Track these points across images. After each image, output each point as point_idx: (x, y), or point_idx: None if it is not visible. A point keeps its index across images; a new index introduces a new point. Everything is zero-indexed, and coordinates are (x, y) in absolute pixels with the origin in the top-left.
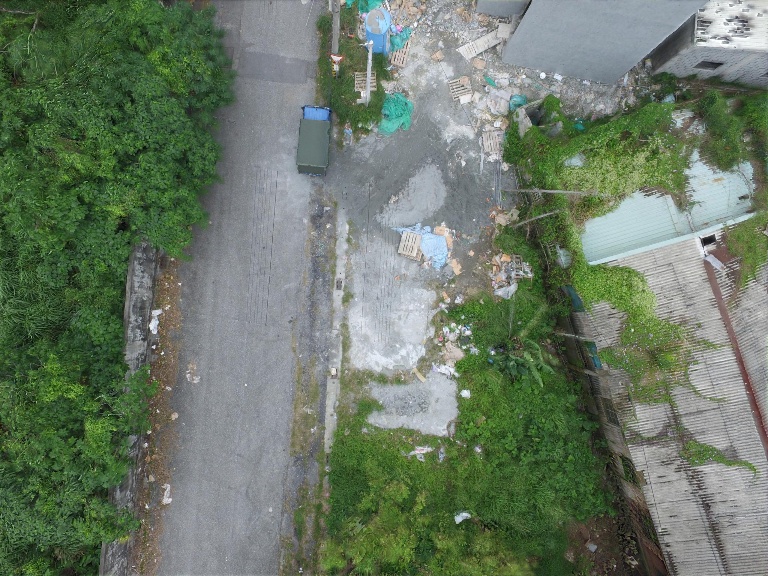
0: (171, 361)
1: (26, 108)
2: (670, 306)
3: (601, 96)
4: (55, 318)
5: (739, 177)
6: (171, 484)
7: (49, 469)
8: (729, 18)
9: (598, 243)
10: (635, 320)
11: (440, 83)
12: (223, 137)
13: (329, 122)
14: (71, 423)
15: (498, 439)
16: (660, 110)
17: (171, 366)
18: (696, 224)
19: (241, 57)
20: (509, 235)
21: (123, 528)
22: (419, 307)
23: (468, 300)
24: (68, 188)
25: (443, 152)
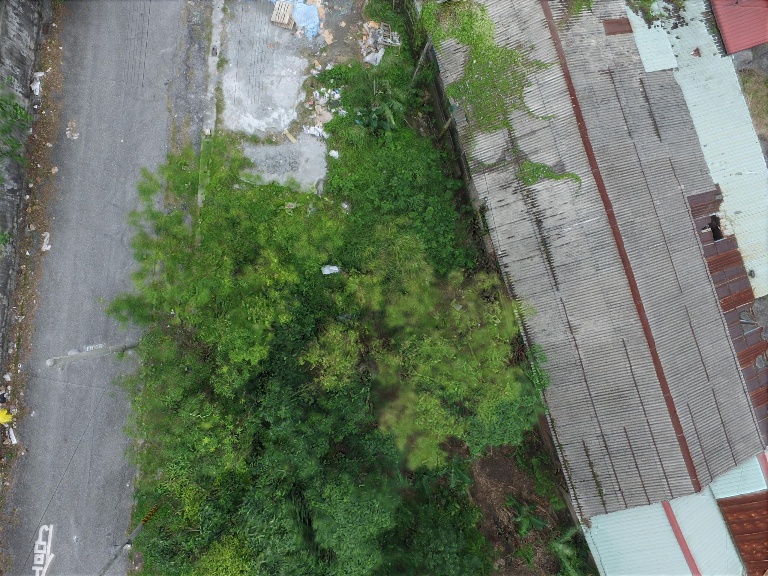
0: (52, 119)
1: None
2: (507, 33)
3: None
4: None
5: None
6: (50, 232)
7: None
8: None
9: None
10: (476, 51)
11: None
12: None
13: None
14: None
15: (361, 191)
16: None
17: (52, 124)
18: None
19: None
20: (377, 3)
21: None
22: (291, 73)
23: (337, 65)
24: None
25: None
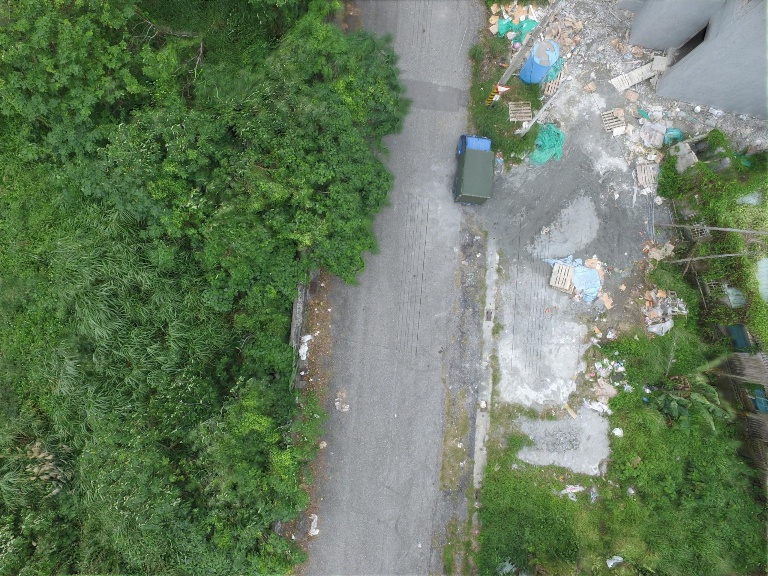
0: (319, 388)
1: (213, 134)
2: None
3: (757, 131)
4: (219, 343)
5: None
6: (318, 515)
7: (229, 501)
8: None
9: None
10: None
11: (592, 114)
12: None
13: (493, 153)
14: (252, 454)
15: (655, 481)
16: None
17: (319, 393)
18: None
19: None
20: (664, 270)
21: (290, 562)
22: (570, 341)
23: (622, 336)
24: (254, 215)
25: (595, 184)
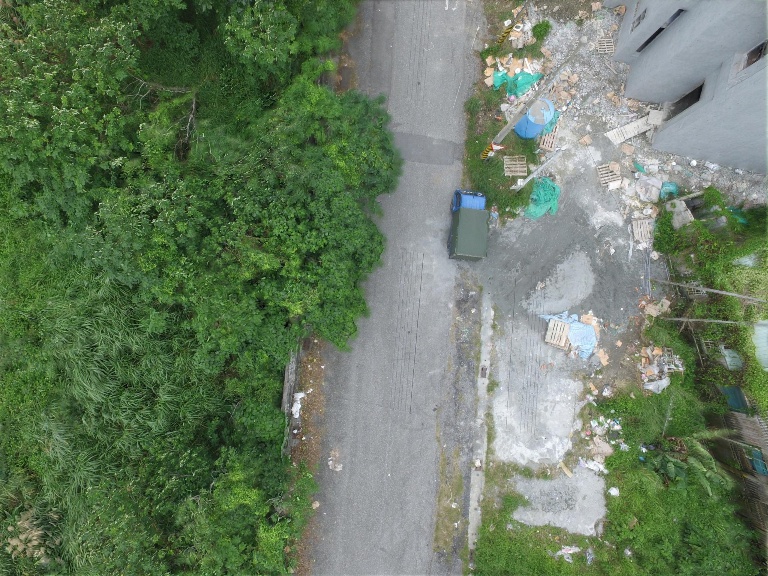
0: (312, 447)
1: (205, 201)
2: None
3: (753, 185)
4: (210, 407)
5: None
6: None
7: None
8: None
9: (767, 346)
10: None
11: (588, 168)
12: None
13: None
14: (242, 528)
15: (652, 543)
16: None
17: (312, 452)
18: None
19: None
20: (661, 327)
21: None
22: (566, 398)
23: (618, 393)
24: (245, 283)
25: (591, 238)
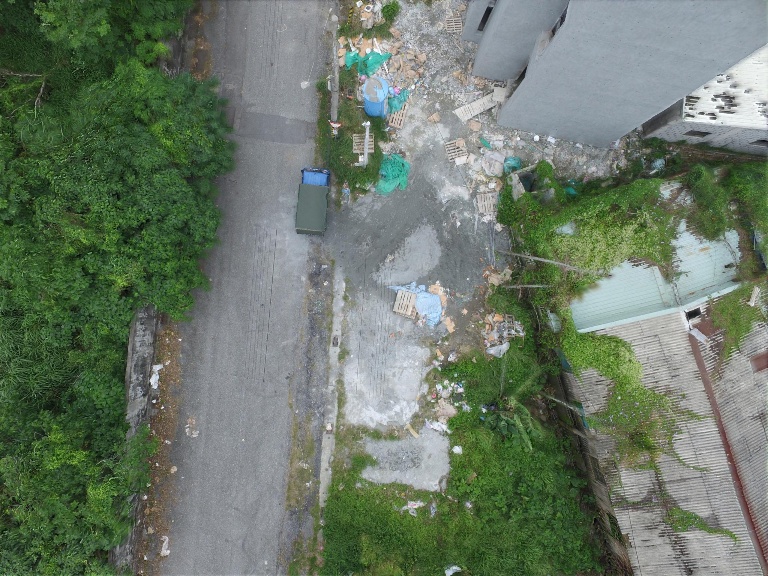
0: (171, 415)
1: (33, 180)
2: (656, 376)
3: (593, 159)
4: (58, 378)
5: (725, 247)
6: (169, 536)
7: (51, 532)
8: (717, 94)
9: (587, 309)
10: (622, 388)
11: (436, 144)
12: (224, 196)
13: (327, 187)
14: (73, 488)
15: (488, 496)
16: (648, 187)
17: (171, 420)
18: (682, 294)
19: (242, 117)
20: (502, 295)
21: None
22: (413, 364)
23: (461, 358)
24: (73, 259)
25: (438, 212)
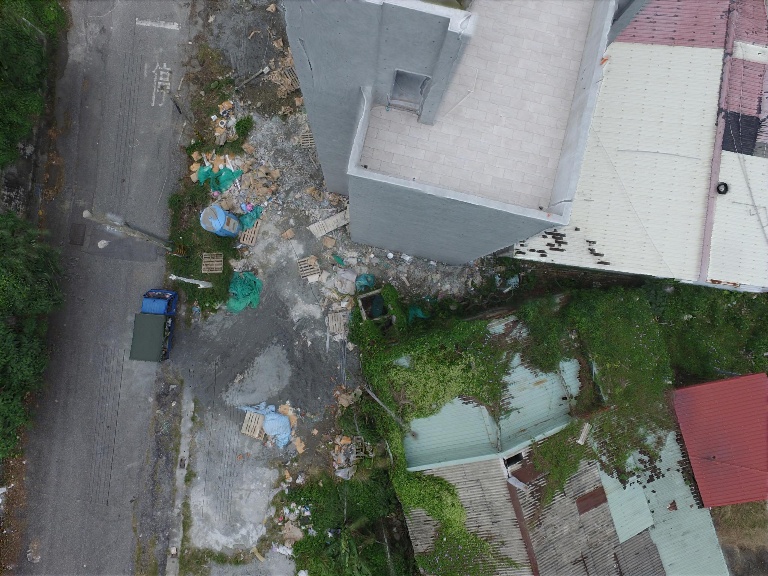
0: (12, 540)
1: None
2: (478, 520)
3: (447, 276)
4: None
5: (560, 381)
6: None
7: None
8: (548, 231)
9: (422, 443)
10: (447, 530)
11: (290, 261)
12: (72, 315)
13: (164, 316)
14: None
15: None
16: (469, 331)
17: (12, 545)
18: (512, 432)
19: (93, 234)
20: (350, 417)
21: None
22: (261, 486)
23: (308, 481)
24: None
25: (290, 330)
